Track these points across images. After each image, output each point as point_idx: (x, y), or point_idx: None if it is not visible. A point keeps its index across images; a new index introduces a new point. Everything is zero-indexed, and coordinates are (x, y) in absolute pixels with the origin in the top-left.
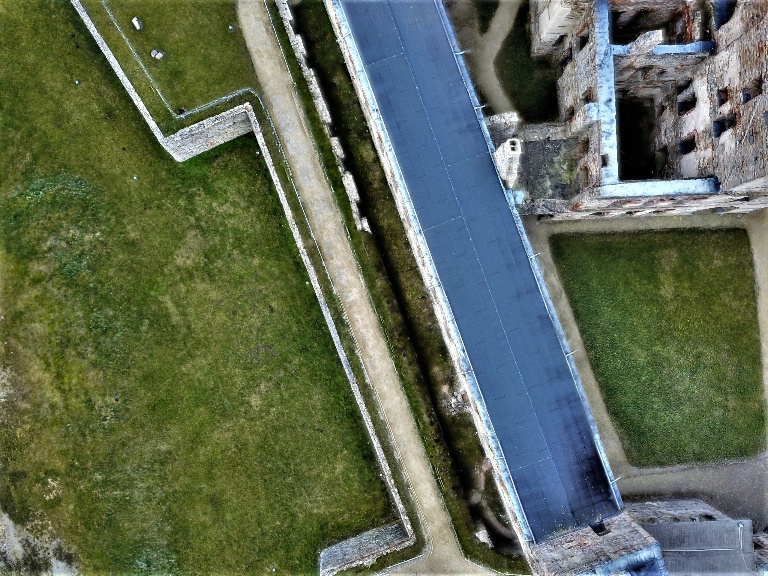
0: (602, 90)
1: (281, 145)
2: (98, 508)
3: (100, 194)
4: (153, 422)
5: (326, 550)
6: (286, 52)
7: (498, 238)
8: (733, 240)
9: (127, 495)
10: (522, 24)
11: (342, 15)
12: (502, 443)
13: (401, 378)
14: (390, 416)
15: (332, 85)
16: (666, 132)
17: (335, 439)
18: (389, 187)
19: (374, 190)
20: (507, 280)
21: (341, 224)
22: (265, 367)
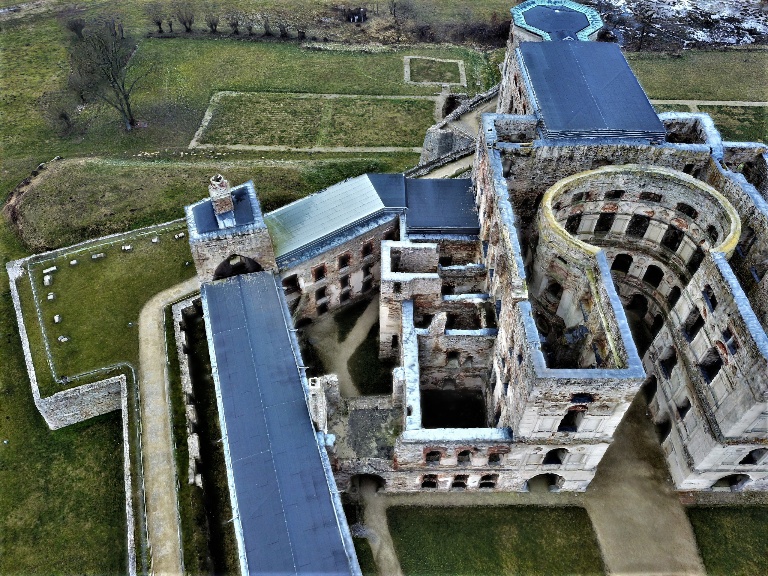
0: (407, 358)
1: (141, 408)
2: None
3: None
4: None
5: None
6: (169, 341)
7: (302, 471)
8: (574, 518)
9: None
10: (374, 337)
11: (206, 304)
12: None
13: None
14: None
15: (204, 370)
16: (489, 412)
17: None
18: None
19: (219, 454)
20: (305, 512)
21: (174, 477)
22: None
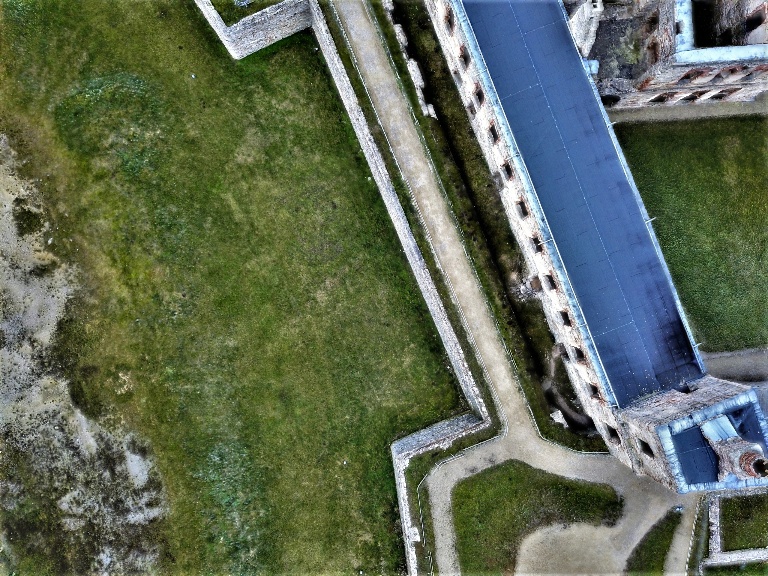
0: None
1: (345, 32)
2: (170, 401)
3: (159, 93)
4: (220, 318)
5: (396, 441)
6: None
7: (576, 105)
8: None
9: (197, 390)
10: None
11: None
12: (584, 310)
13: (472, 262)
14: (462, 300)
15: None
16: (730, 13)
17: (401, 333)
18: (452, 76)
19: (437, 80)
20: (586, 147)
21: (408, 110)
22: (329, 263)
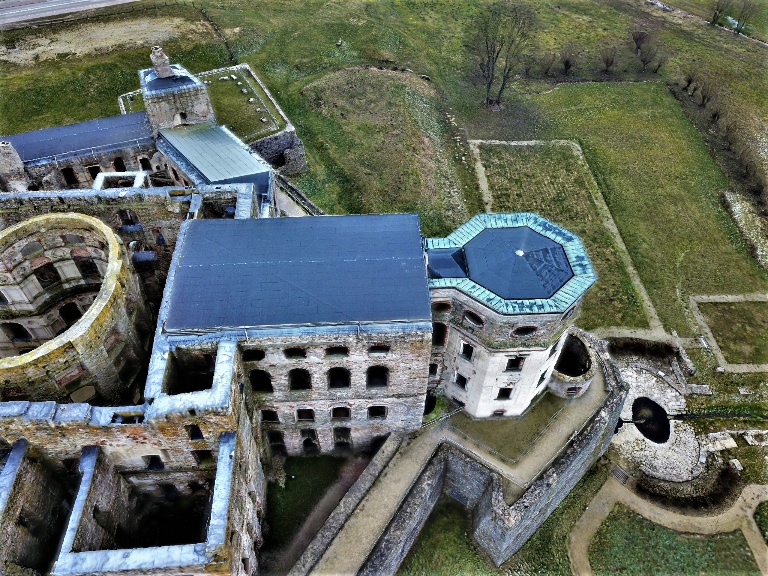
0: None
1: None
2: None
3: (115, 95)
4: None
5: None
6: None
7: None
8: None
9: None
10: None
11: None
12: None
13: None
14: None
15: None
16: None
17: None
18: None
19: None
20: None
21: None
22: None
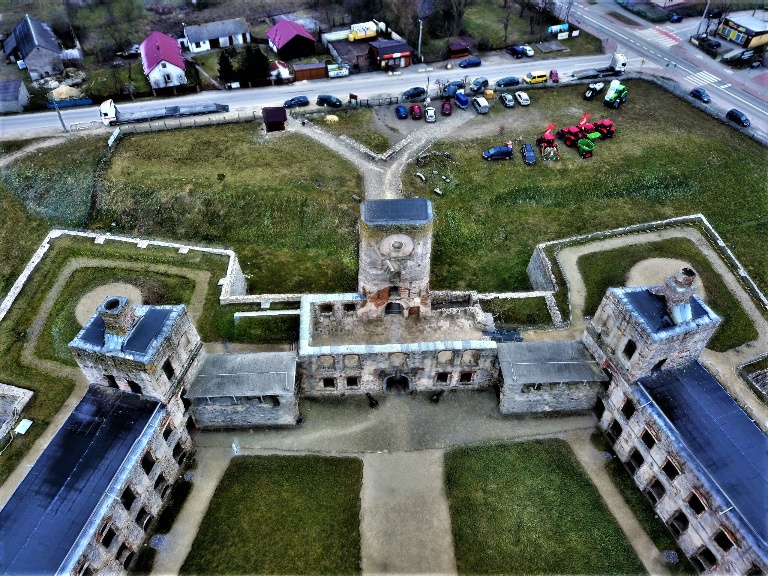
0: None
1: None
2: None
3: None
4: None
5: None
6: None
7: None
8: None
9: None
10: None
11: None
12: (759, 431)
13: None
14: None
15: None
16: None
17: None
18: None
19: None
20: None
21: None
22: None
